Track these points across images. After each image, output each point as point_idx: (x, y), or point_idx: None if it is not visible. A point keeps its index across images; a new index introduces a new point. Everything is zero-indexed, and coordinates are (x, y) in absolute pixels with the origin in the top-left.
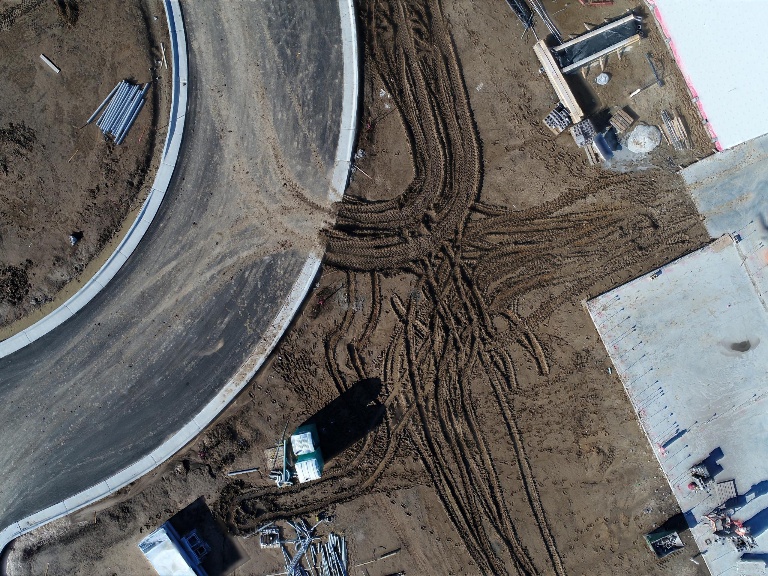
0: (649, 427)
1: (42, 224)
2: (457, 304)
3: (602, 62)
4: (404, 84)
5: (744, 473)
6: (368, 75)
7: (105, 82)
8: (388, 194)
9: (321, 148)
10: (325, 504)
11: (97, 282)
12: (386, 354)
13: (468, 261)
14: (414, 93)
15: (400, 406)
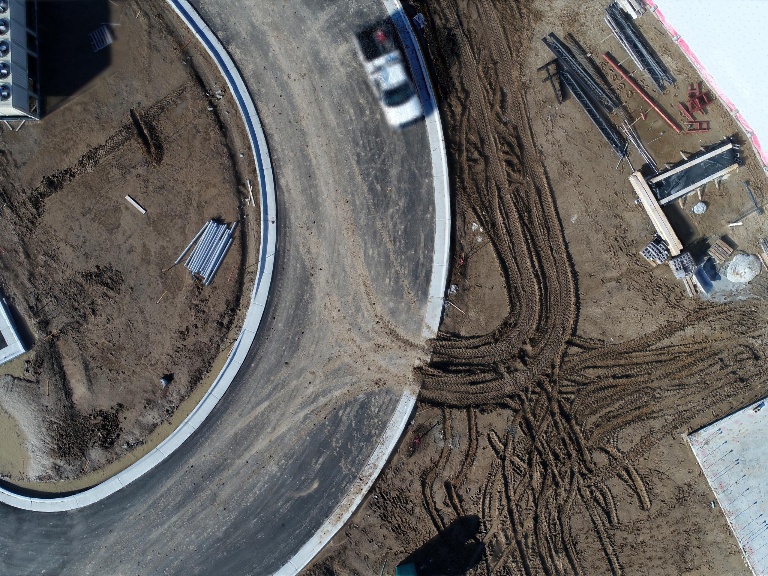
0: (754, 561)
1: (132, 367)
2: (555, 439)
3: (699, 191)
4: (497, 217)
5: None
6: (460, 209)
7: (192, 222)
8: (482, 329)
9: (414, 284)
10: None
11: (189, 424)
12: (484, 491)
13: (566, 396)
14: (507, 226)
15: (499, 543)
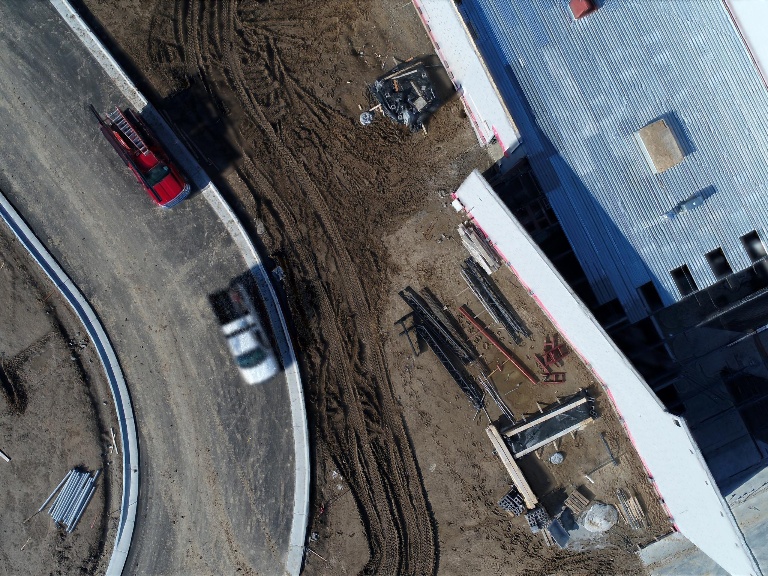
0: None
1: None
2: None
3: (556, 442)
4: (357, 465)
5: None
6: (320, 458)
7: (56, 469)
8: (344, 575)
9: (275, 532)
10: None
11: None
12: None
13: None
14: (367, 474)
15: None
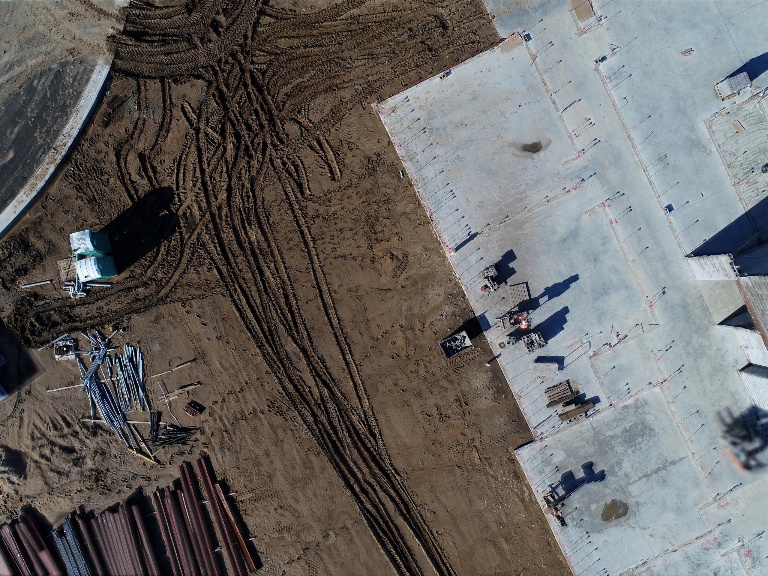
0: (441, 230)
1: None
2: (248, 110)
3: None
4: None
5: (537, 275)
6: None
7: None
8: None
9: None
10: (120, 315)
11: None
12: (178, 162)
13: (258, 66)
14: None
15: (193, 215)
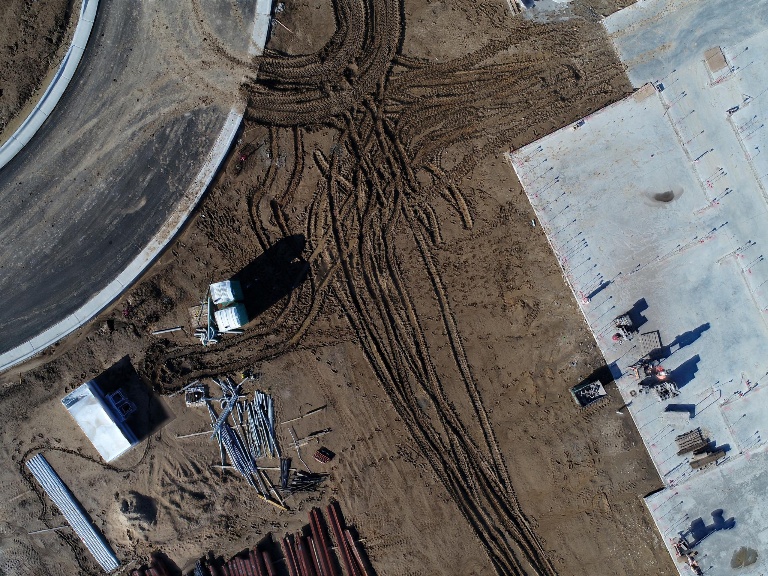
0: (573, 279)
1: None
2: (380, 159)
3: None
4: None
5: (668, 324)
6: None
7: None
8: (309, 48)
9: (241, 2)
10: (250, 362)
11: (17, 141)
12: (309, 210)
13: (390, 115)
14: None
15: (324, 263)
